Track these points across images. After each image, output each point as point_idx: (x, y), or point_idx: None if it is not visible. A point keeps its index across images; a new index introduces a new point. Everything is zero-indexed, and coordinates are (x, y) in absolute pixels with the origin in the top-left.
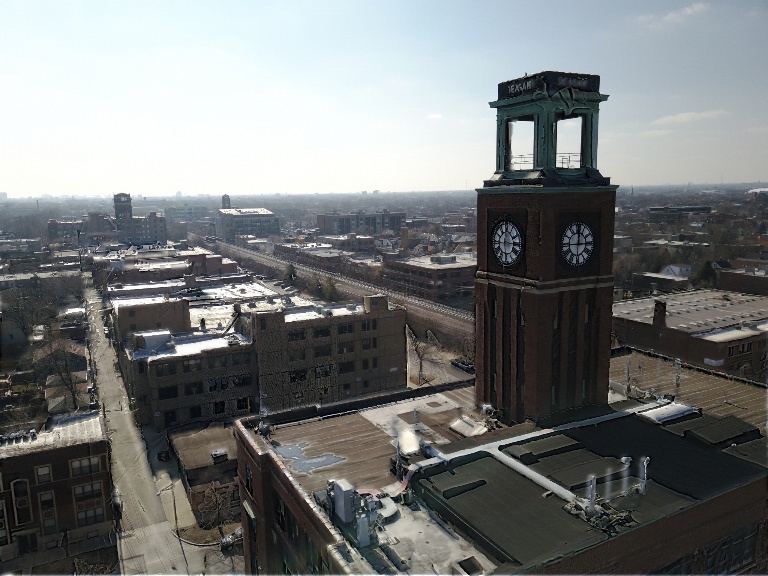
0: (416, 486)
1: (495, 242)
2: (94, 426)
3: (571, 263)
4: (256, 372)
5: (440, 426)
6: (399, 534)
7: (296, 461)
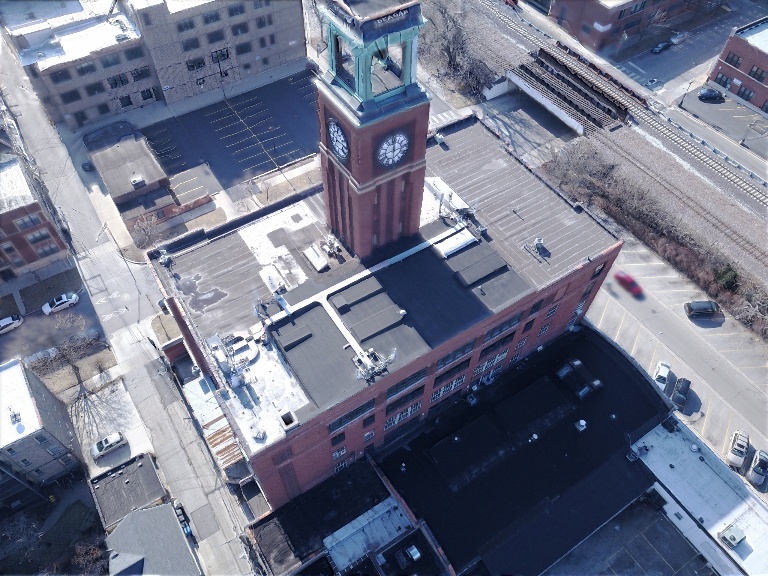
0: (270, 333)
1: (331, 132)
2: (19, 177)
3: (388, 164)
4: (152, 66)
5: (297, 250)
6: (258, 374)
7: (193, 298)
